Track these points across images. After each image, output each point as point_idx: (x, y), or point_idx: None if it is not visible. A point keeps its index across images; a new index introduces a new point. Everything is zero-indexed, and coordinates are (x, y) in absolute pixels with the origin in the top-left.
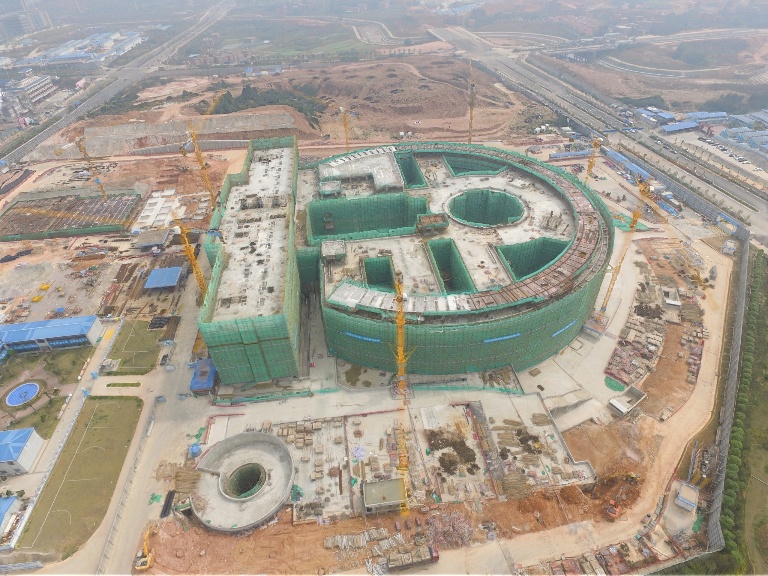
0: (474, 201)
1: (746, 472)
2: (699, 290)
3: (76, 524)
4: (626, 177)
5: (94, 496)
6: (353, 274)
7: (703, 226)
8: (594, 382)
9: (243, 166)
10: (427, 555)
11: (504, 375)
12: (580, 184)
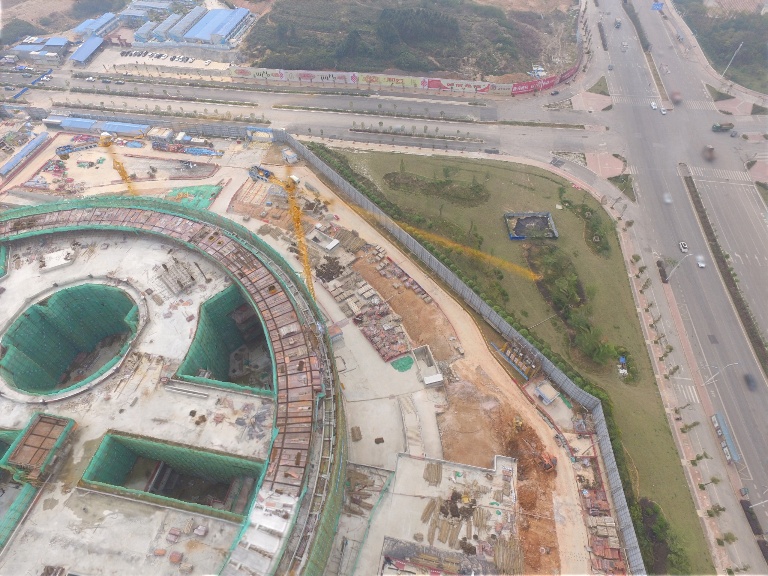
0: (27, 336)
1: (535, 334)
2: (326, 214)
3: None
4: (120, 143)
5: None
6: None
7: (246, 149)
8: (393, 380)
9: None
10: None
11: (359, 481)
12: (133, 201)
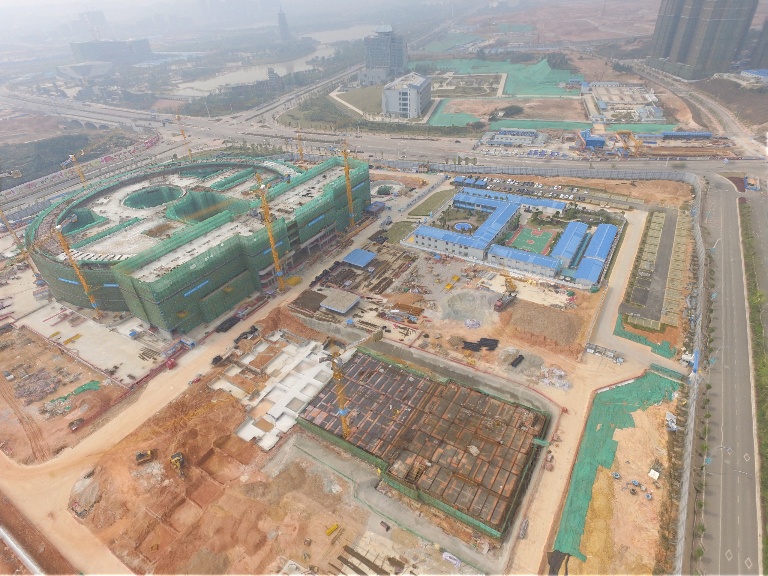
0: None
1: None
2: None
3: None
4: None
5: None
6: None
7: None
8: None
9: (224, 240)
10: None
11: None
12: None
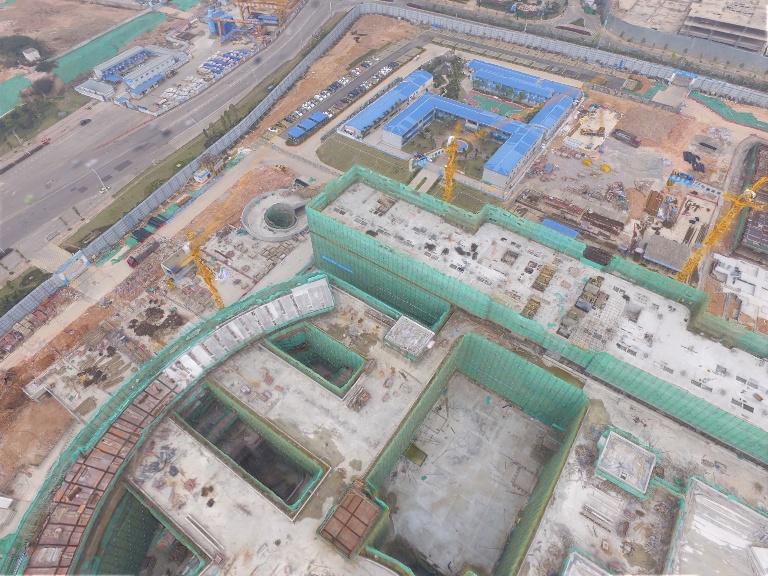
0: None
1: None
2: None
3: (329, 153)
4: None
5: (340, 161)
6: (356, 339)
7: None
8: None
9: None
10: (132, 254)
11: None
12: None
